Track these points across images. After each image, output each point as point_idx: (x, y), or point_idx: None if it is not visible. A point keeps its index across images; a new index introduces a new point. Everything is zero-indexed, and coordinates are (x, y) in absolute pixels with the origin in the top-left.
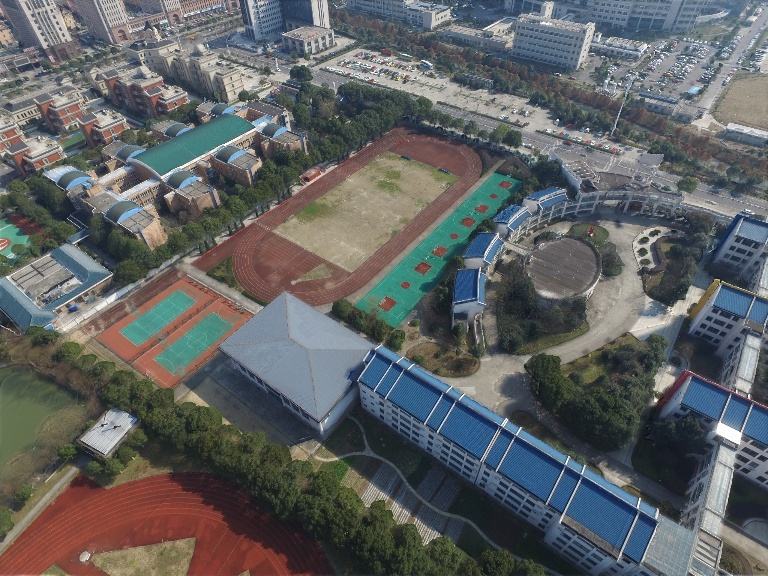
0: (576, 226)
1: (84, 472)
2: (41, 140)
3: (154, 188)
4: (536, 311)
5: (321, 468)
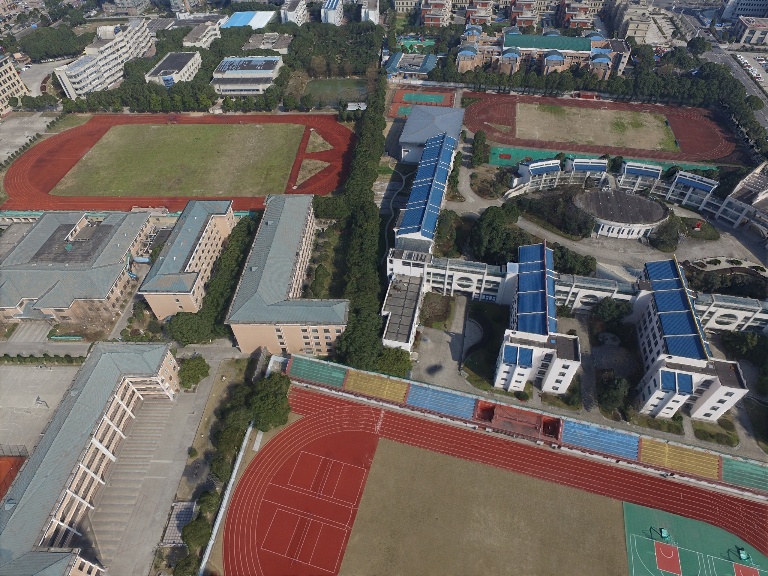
0: (698, 219)
1: (340, 115)
2: (487, 11)
3: (496, 52)
4: None
5: (385, 167)
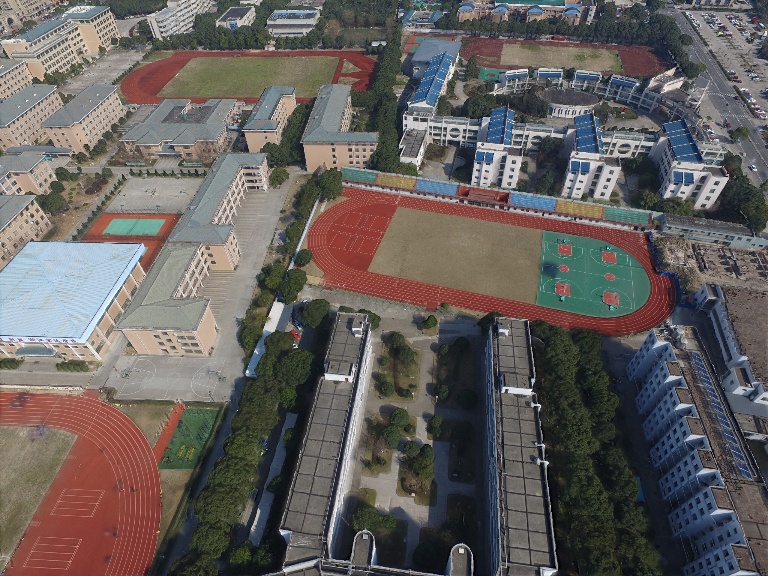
0: None
1: (366, 51)
2: None
3: (490, 8)
4: None
5: None
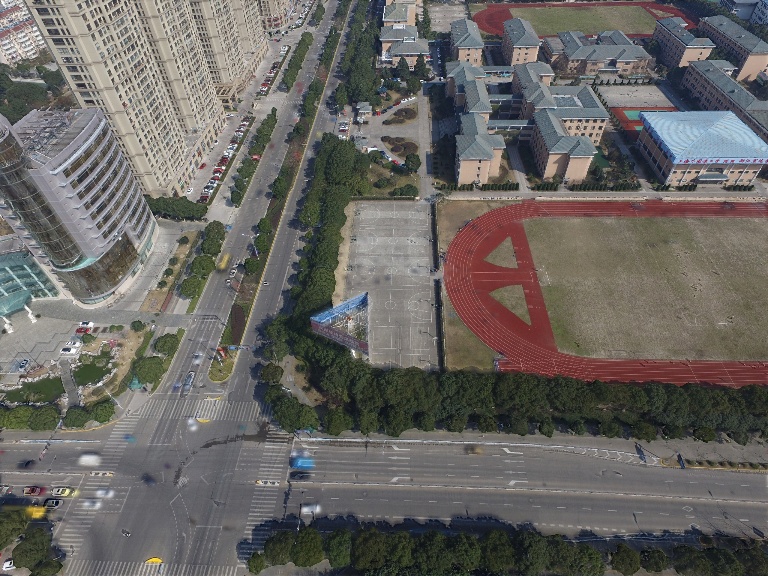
0: None
1: None
2: None
3: None
4: None
5: None
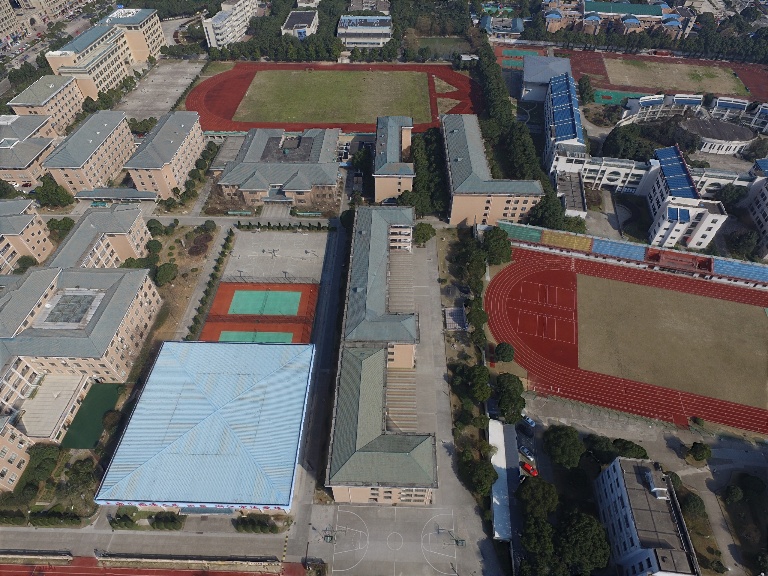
0: None
1: (453, 65)
2: None
3: (577, 16)
4: (667, 130)
5: None
